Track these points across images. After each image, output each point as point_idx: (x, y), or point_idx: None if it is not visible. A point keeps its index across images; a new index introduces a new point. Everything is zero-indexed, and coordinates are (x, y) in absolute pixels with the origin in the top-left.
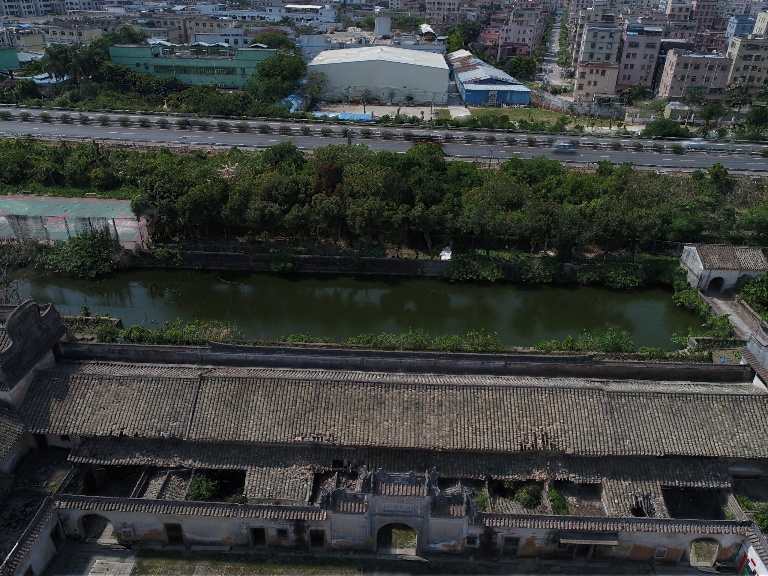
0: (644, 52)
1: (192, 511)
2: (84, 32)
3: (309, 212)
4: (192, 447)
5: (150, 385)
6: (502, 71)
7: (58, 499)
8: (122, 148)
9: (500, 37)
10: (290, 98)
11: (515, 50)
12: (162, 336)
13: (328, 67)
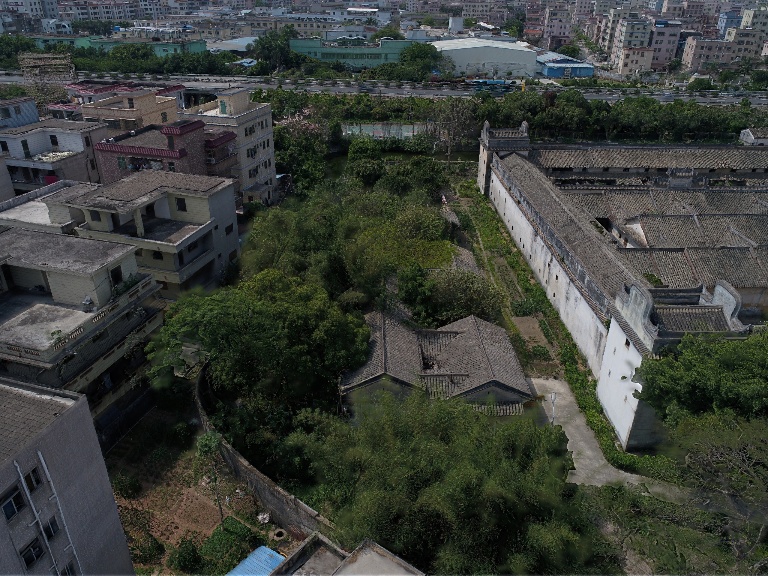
0: (668, 39)
1: (606, 188)
2: (221, 31)
3: (545, 117)
4: (592, 174)
5: (571, 153)
6: (564, 55)
7: (557, 186)
8: (377, 98)
9: (546, 31)
10: (435, 73)
11: (560, 41)
12: None
13: (451, 52)
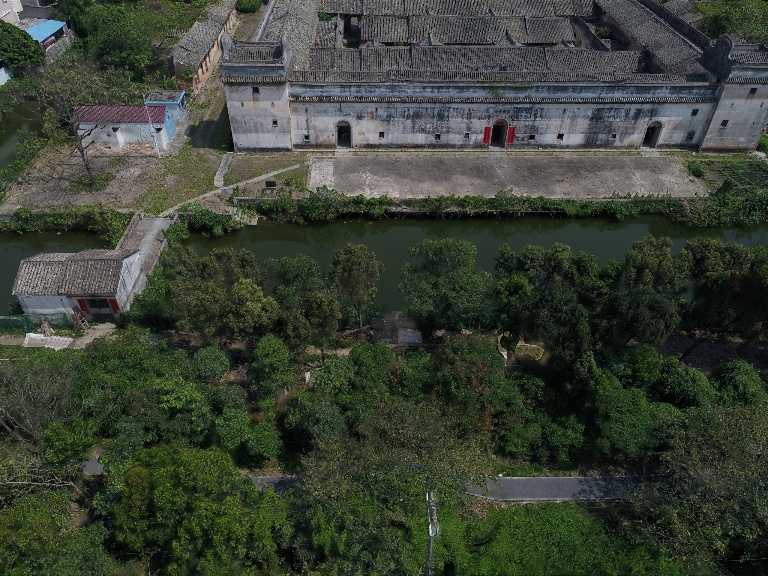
0: None
1: None
2: None
3: None
4: None
5: None
6: None
7: None
8: None
9: None
10: None
11: None
12: (728, 185)
13: None
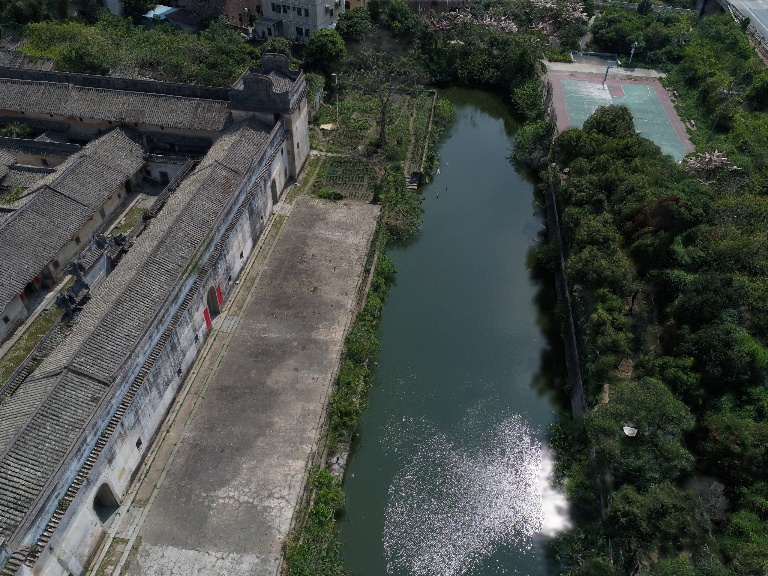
0: None
1: None
2: None
3: None
4: None
5: None
6: None
7: None
8: None
9: None
10: None
11: None
12: None
13: None
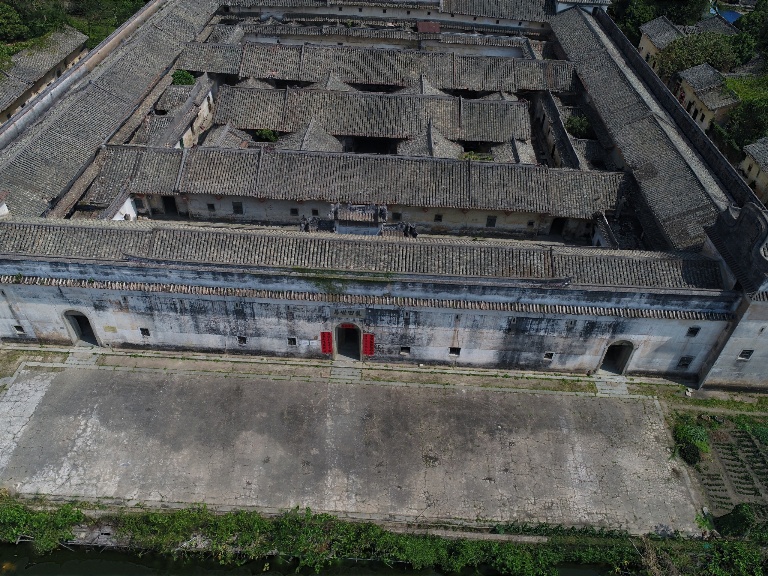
0: None
1: None
2: None
3: None
4: None
5: None
6: None
7: None
8: None
9: None
10: None
11: None
12: (741, 520)
13: None
